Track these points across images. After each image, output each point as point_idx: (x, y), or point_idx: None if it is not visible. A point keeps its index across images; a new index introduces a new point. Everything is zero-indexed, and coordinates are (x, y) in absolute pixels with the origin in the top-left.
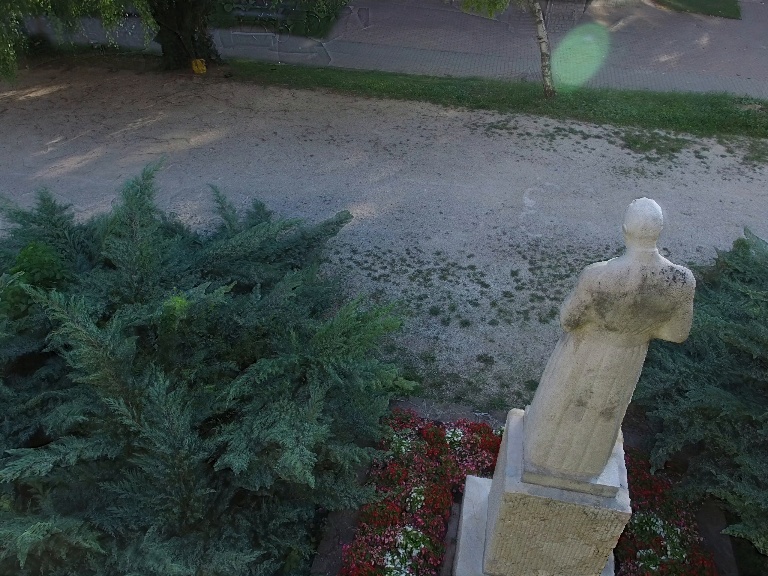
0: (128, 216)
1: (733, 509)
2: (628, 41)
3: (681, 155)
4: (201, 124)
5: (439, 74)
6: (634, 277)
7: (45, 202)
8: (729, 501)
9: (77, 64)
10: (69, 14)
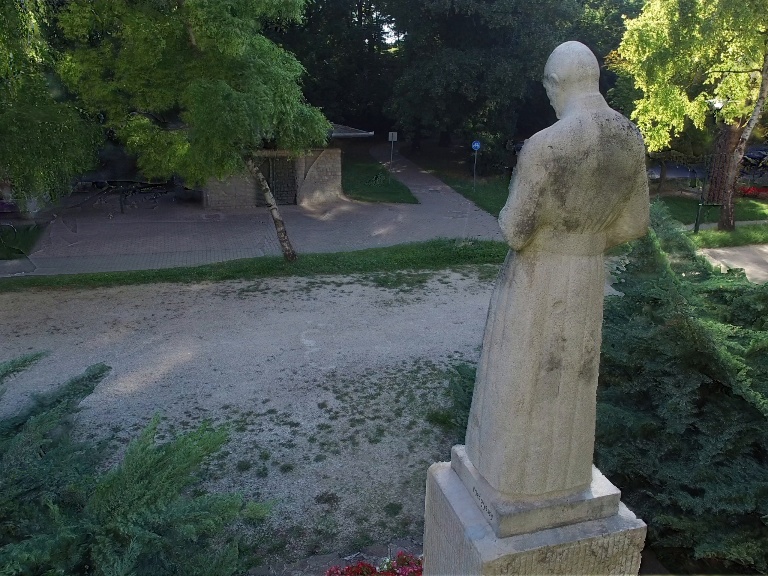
0: None
1: (676, 542)
2: (339, 226)
3: (429, 284)
4: None
5: None
6: (589, 128)
7: None
8: (675, 527)
9: None
10: None
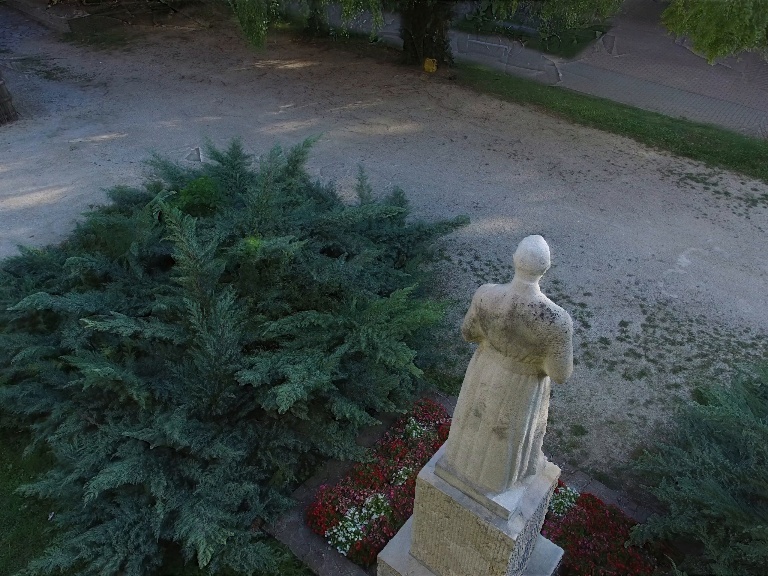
0: (267, 170)
1: None
2: None
3: None
4: (406, 116)
5: (674, 115)
6: (506, 302)
7: (235, 148)
8: None
9: (335, 46)
10: (319, 3)
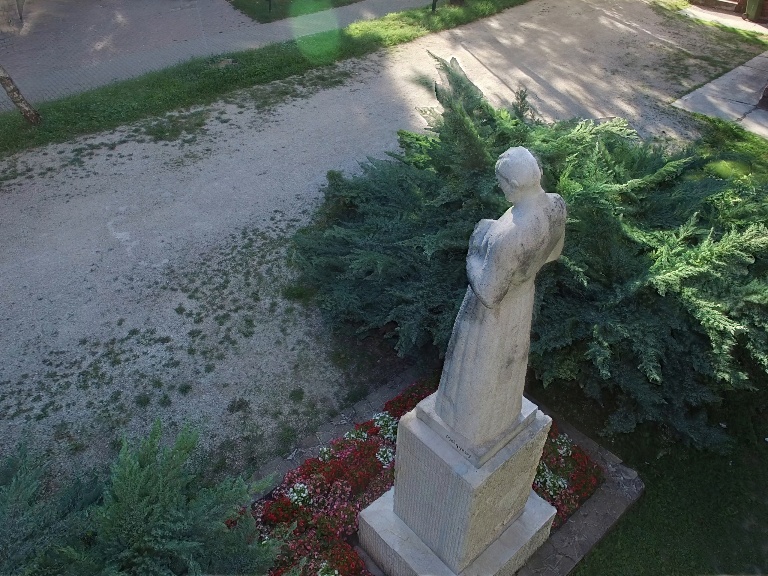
0: None
1: None
2: (48, 40)
3: (209, 126)
4: None
5: None
6: (544, 222)
7: None
8: None
9: None
10: None
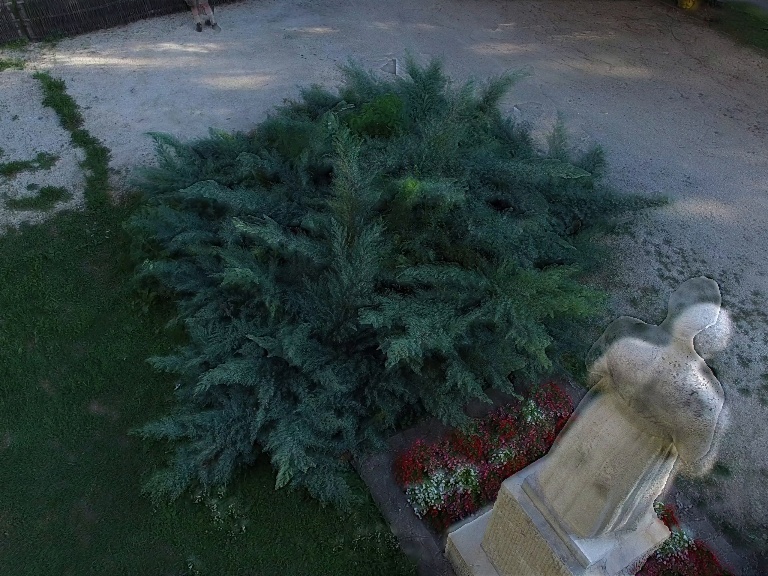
0: (452, 99)
1: None
2: None
3: None
4: (637, 57)
5: None
6: (644, 350)
7: (432, 66)
8: None
9: None
10: None
